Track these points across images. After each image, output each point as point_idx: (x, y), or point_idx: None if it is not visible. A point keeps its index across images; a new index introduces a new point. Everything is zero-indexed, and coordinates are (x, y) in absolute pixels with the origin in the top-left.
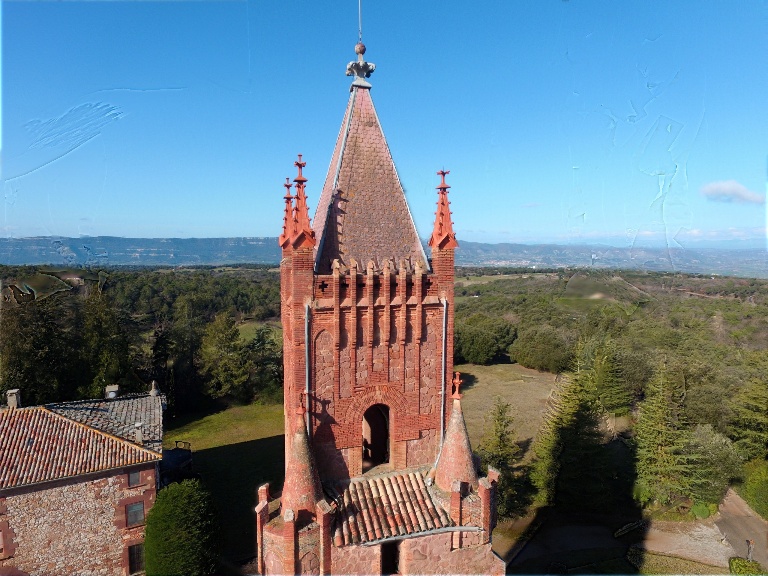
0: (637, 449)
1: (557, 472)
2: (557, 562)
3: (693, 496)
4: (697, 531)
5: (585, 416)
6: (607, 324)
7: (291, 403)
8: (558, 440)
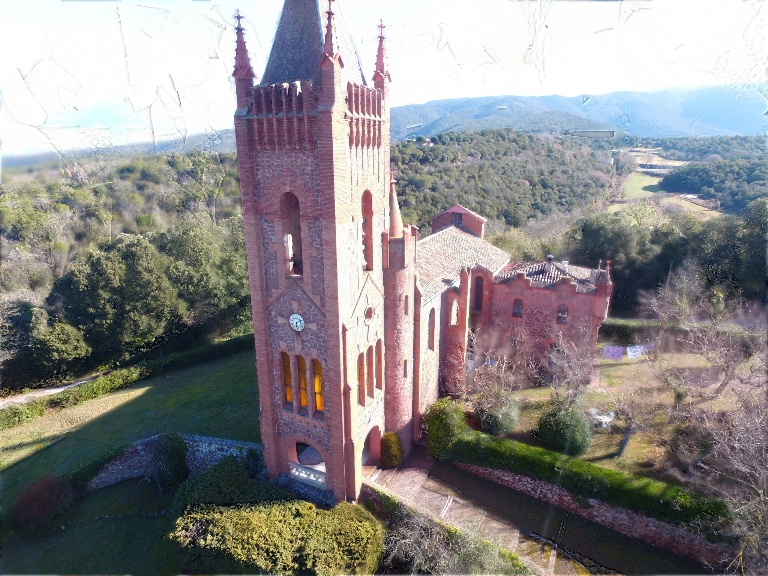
0: None
1: None
2: None
3: None
4: None
5: None
6: None
7: None
8: None
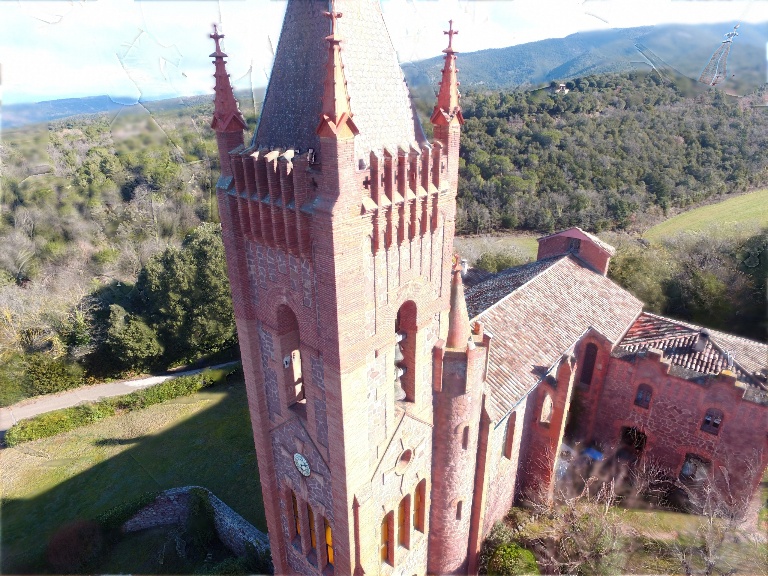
0: None
1: None
2: None
3: None
4: None
5: None
6: None
7: (423, 301)
8: None
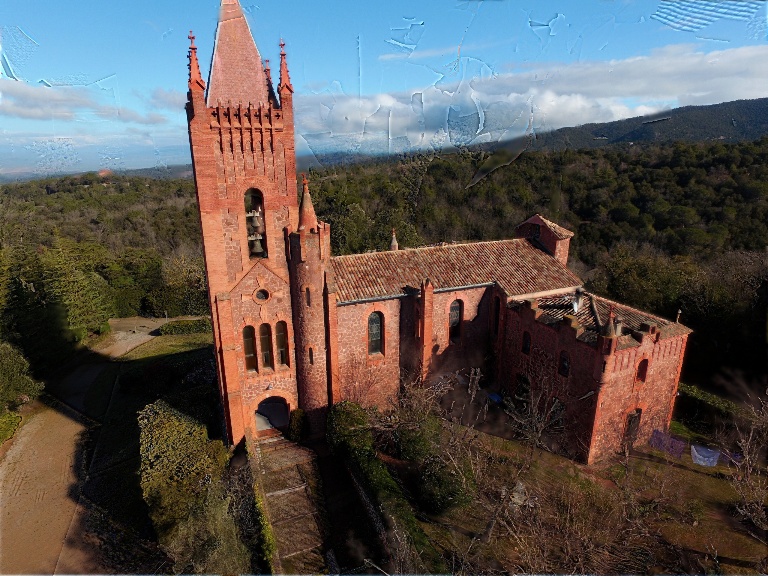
0: (64, 302)
1: (22, 351)
2: (102, 388)
3: (109, 316)
4: (118, 337)
5: (22, 291)
6: (8, 200)
7: (269, 192)
8: (11, 322)
